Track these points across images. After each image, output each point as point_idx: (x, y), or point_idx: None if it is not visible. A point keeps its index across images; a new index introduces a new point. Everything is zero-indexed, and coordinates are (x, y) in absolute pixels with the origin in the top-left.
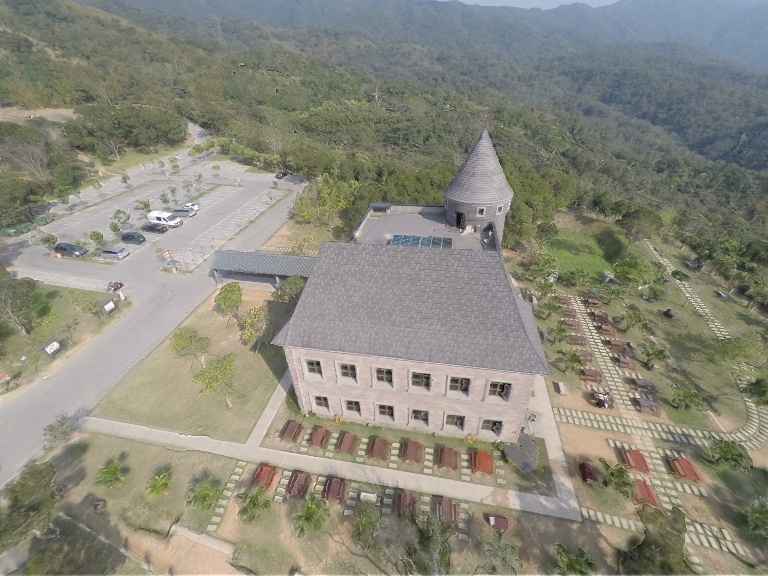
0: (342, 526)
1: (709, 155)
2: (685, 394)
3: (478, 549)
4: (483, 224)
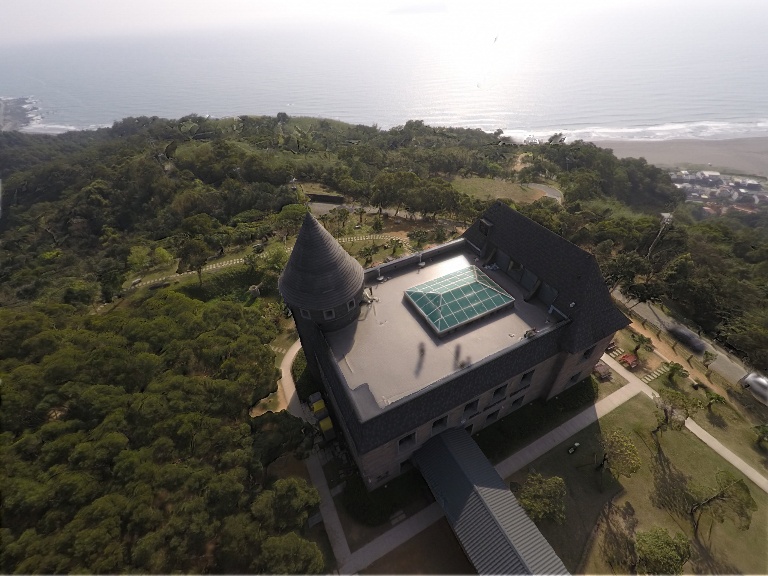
0: None
1: None
2: (395, 243)
3: None
4: None
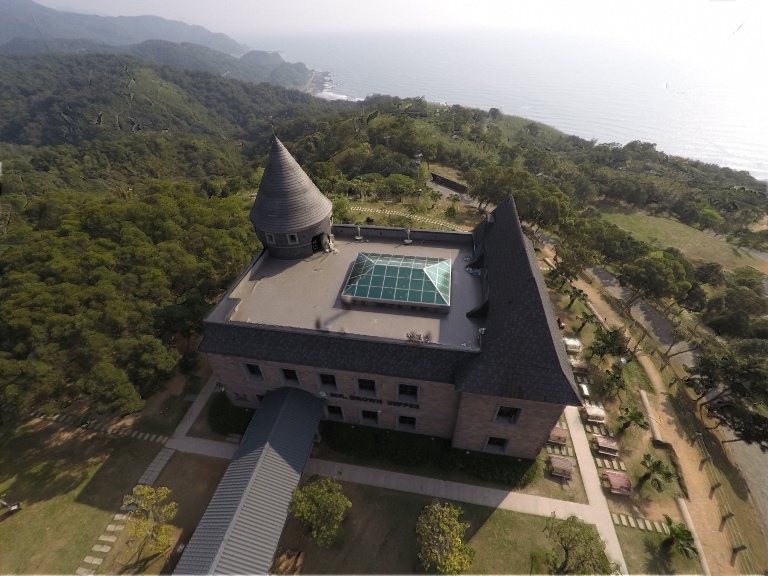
0: (610, 410)
1: (50, 141)
2: None
3: (579, 336)
4: (330, 231)
